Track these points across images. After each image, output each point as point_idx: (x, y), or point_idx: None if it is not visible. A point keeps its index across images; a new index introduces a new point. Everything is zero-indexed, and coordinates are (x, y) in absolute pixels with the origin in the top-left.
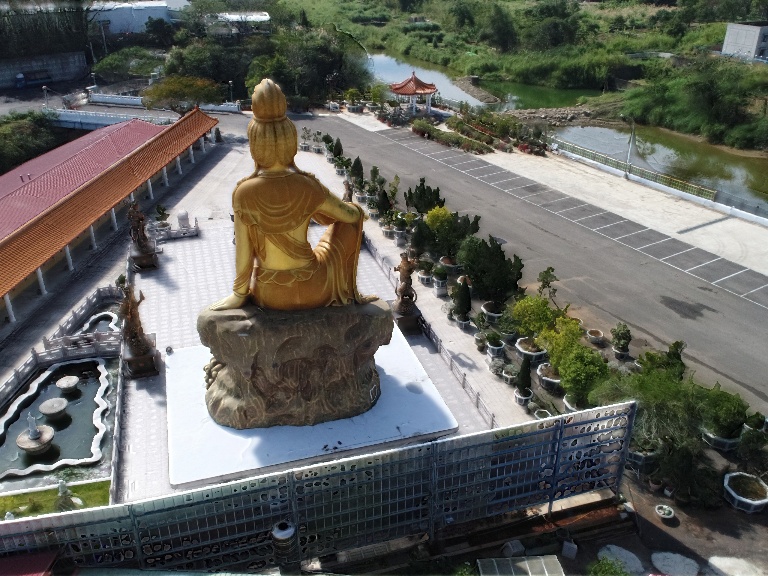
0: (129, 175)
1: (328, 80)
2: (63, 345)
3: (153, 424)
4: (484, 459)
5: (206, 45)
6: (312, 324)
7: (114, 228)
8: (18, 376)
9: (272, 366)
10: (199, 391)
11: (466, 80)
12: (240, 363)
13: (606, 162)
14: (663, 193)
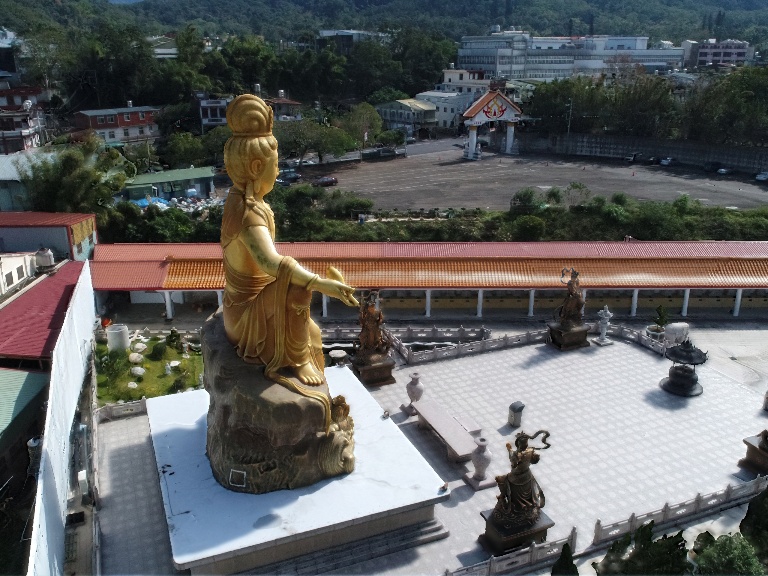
0: (702, 273)
1: None
2: None
3: None
4: None
5: None
6: None
7: (631, 312)
8: (339, 333)
9: None
10: None
11: None
12: None
13: None
14: None
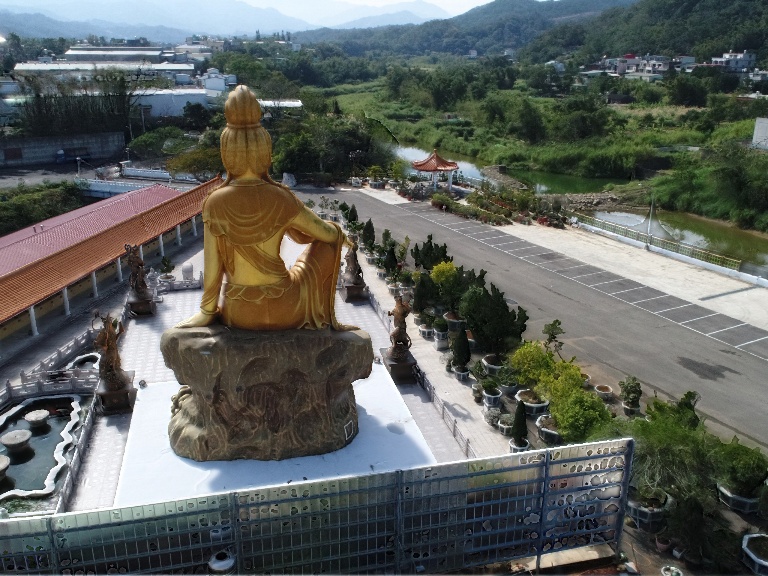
0: (140, 230)
1: (351, 157)
2: (39, 379)
3: (116, 459)
4: None
5: None
6: (280, 344)
7: (119, 279)
8: None
9: (236, 390)
10: (165, 423)
11: (493, 168)
12: (202, 385)
13: (626, 234)
14: (685, 263)
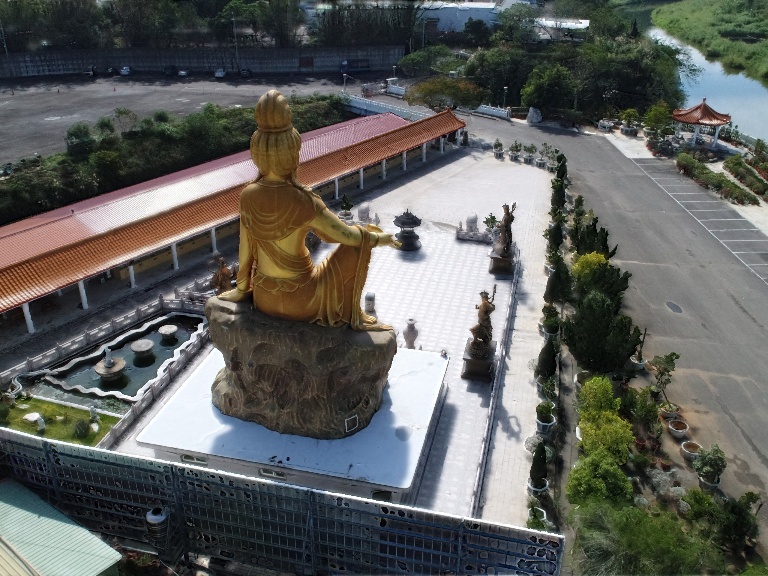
0: (340, 163)
1: (605, 97)
2: (182, 298)
3: None
4: (371, 529)
5: (510, 49)
6: (284, 335)
7: None
8: (140, 314)
9: (248, 364)
10: None
11: None
12: (224, 353)
13: None
14: None
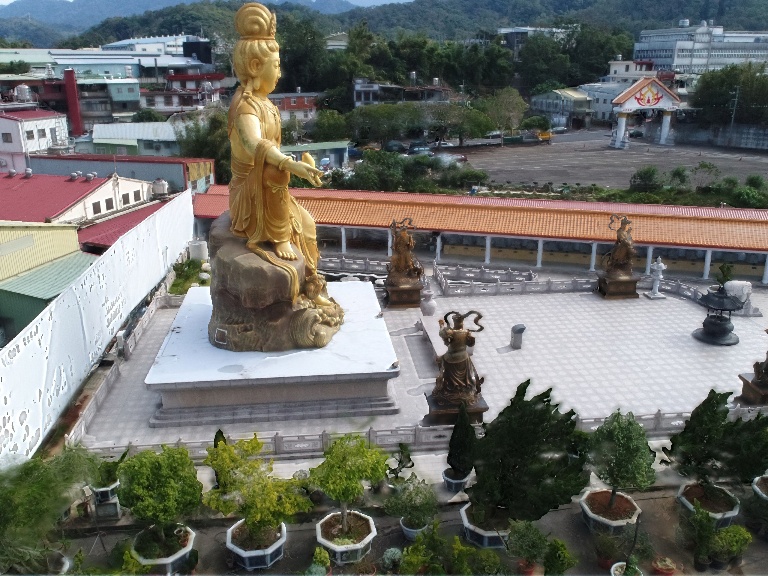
0: None
1: None
2: None
3: None
4: None
5: None
6: None
7: None
8: None
9: None
10: None
11: None
12: None
13: None
14: None
